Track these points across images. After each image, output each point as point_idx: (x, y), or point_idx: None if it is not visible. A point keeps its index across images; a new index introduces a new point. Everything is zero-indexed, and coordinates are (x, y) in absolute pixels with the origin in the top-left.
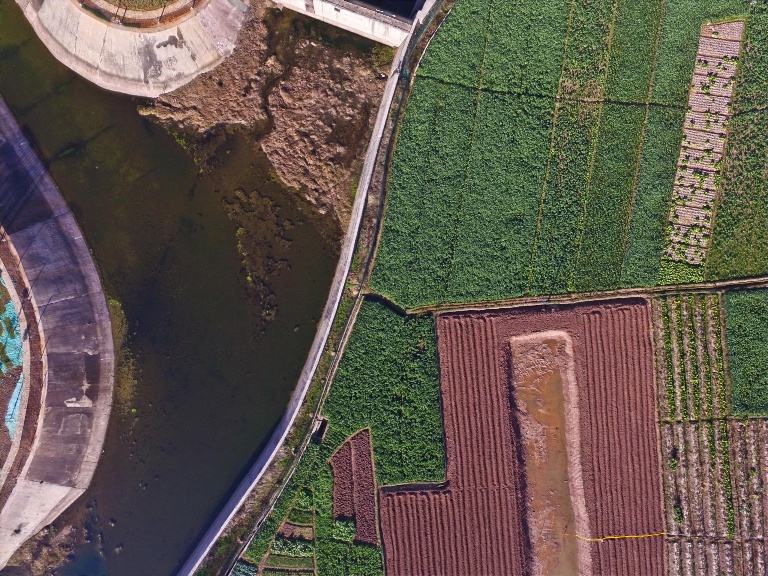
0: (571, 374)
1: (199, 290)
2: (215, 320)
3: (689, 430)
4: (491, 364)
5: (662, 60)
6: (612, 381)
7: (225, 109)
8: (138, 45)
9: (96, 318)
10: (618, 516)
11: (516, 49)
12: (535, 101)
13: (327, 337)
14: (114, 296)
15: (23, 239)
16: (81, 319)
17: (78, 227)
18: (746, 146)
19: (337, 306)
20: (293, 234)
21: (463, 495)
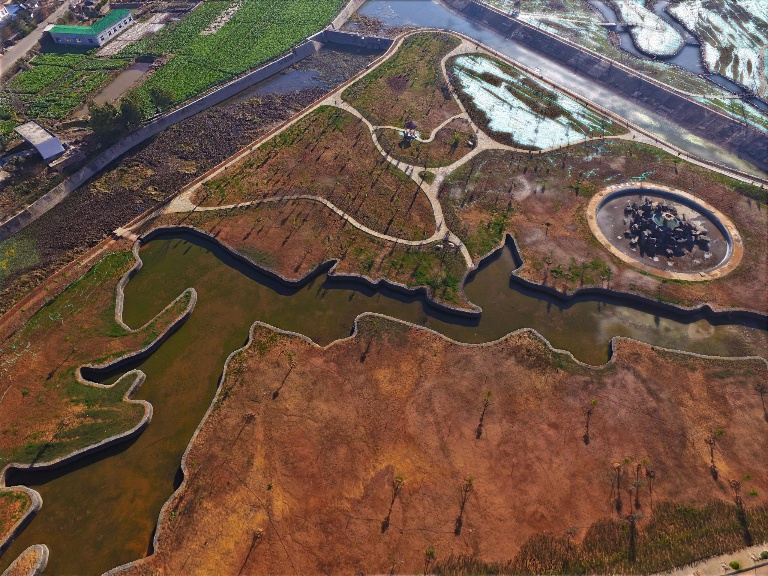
0: None
1: None
2: None
3: None
4: None
5: None
6: None
7: None
8: None
9: None
10: None
11: None
12: None
13: None
14: (437, 4)
15: (467, 2)
16: None
17: None
18: None
19: None
20: None
21: None
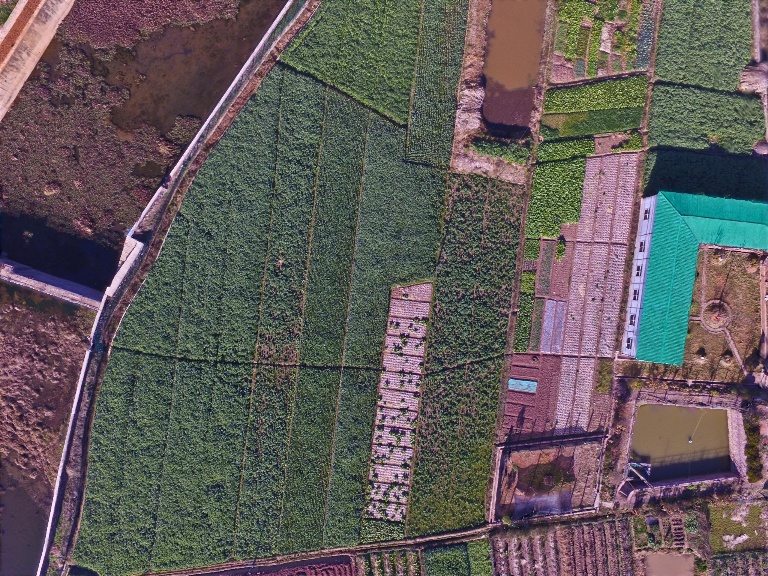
0: None
1: None
2: None
3: None
4: None
5: (352, 326)
6: None
7: None
8: None
9: None
10: None
11: (210, 319)
12: (231, 369)
13: None
14: None
15: None
16: None
17: None
18: (439, 404)
19: None
20: (5, 499)
21: None
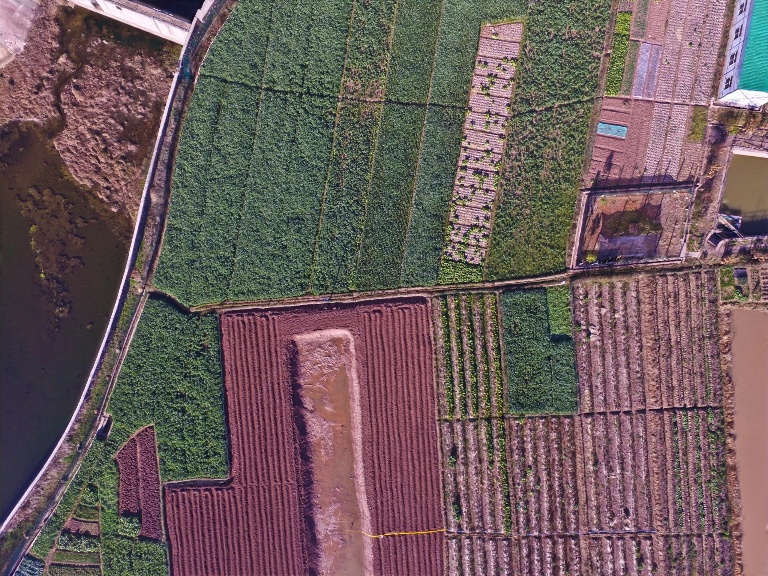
0: (354, 372)
1: None
2: (9, 317)
3: (468, 428)
4: (273, 362)
5: (440, 61)
6: (392, 379)
7: (17, 106)
8: None
9: None
10: (398, 513)
11: (297, 49)
12: (316, 101)
13: (108, 334)
14: None
15: None
16: None
17: None
18: (525, 147)
19: (118, 304)
20: (86, 232)
21: (246, 492)
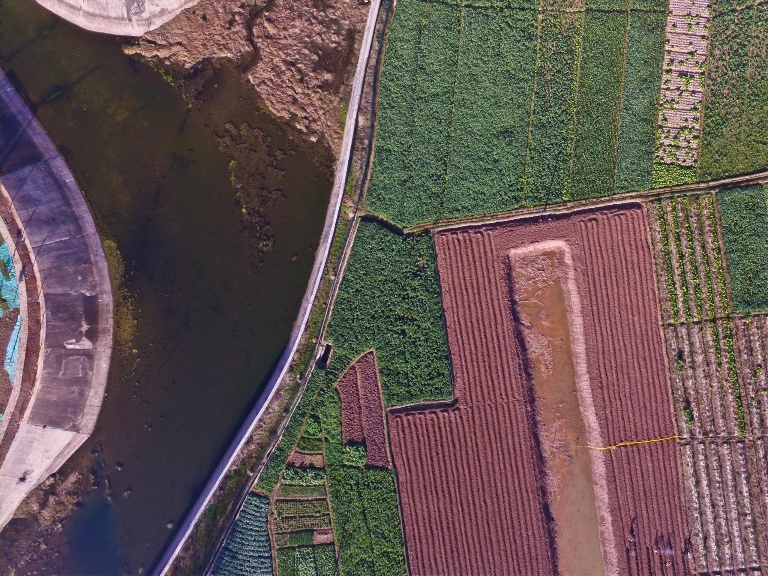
0: (572, 283)
1: (194, 226)
2: (212, 255)
3: (693, 331)
4: (492, 278)
5: None
6: (613, 287)
7: (211, 43)
8: None
9: (92, 259)
10: (629, 422)
11: None
12: (518, 14)
13: (326, 260)
14: (109, 237)
15: (14, 181)
16: (77, 260)
17: (69, 170)
18: (729, 46)
19: (334, 228)
20: (286, 164)
21: (472, 411)
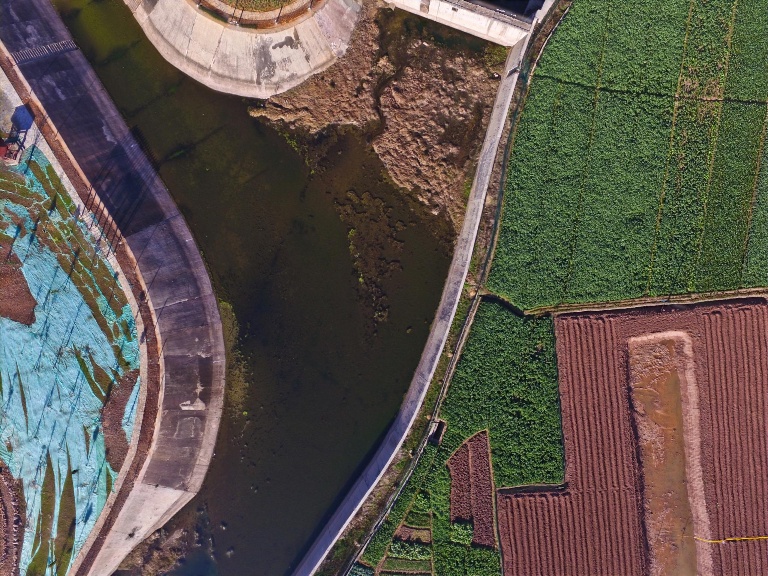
0: (690, 375)
1: (310, 292)
2: (326, 322)
3: None
4: (610, 365)
5: None
6: (733, 382)
7: (337, 110)
8: (254, 46)
9: (208, 321)
10: (739, 517)
11: (635, 48)
12: (655, 100)
13: (446, 339)
14: (225, 298)
15: (138, 242)
16: (194, 322)
17: (188, 229)
18: None
19: (456, 307)
20: (405, 235)
21: (582, 497)
